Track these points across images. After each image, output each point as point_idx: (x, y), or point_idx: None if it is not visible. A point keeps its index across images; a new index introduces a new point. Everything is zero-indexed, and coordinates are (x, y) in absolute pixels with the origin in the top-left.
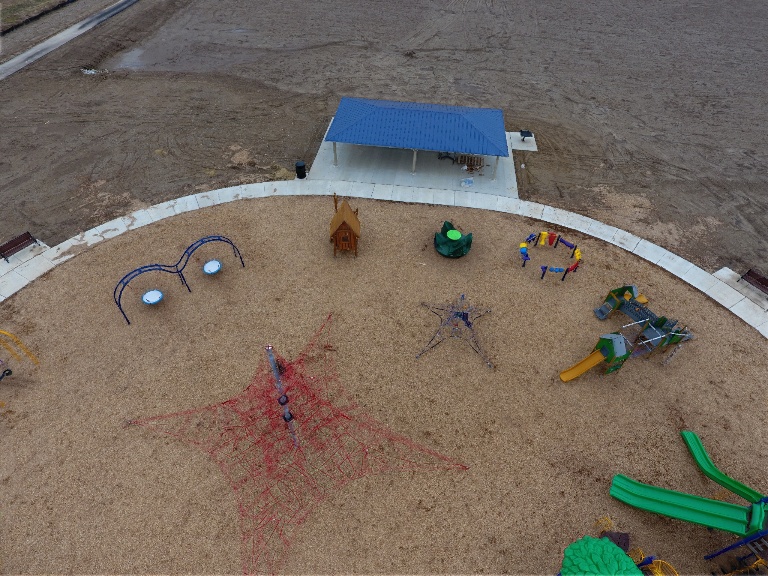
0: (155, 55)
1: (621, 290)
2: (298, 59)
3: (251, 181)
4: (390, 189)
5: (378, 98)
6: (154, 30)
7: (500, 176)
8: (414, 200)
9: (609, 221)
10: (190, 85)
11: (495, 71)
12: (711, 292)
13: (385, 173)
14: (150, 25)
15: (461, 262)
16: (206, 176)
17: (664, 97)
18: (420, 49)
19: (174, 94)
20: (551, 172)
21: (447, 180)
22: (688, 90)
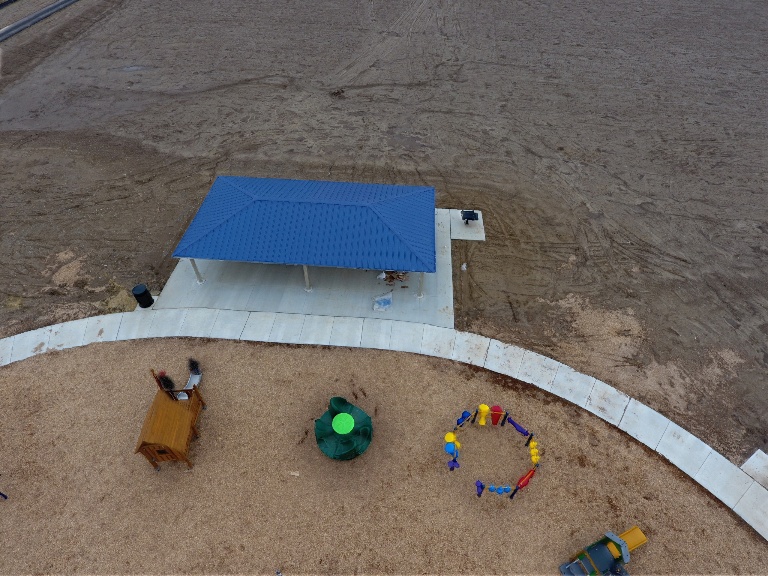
0: (15, 106)
1: (602, 540)
2: (196, 106)
3: (69, 316)
4: (270, 320)
5: (285, 160)
6: (26, 71)
7: (430, 288)
8: (302, 340)
9: (582, 365)
10: (35, 154)
11: (440, 113)
12: (743, 508)
13: (268, 291)
14: (22, 65)
15: (356, 466)
16: (5, 311)
17: (649, 143)
18: (351, 85)
19: (8, 170)
20: (502, 276)
21: (355, 299)
22: (678, 132)
